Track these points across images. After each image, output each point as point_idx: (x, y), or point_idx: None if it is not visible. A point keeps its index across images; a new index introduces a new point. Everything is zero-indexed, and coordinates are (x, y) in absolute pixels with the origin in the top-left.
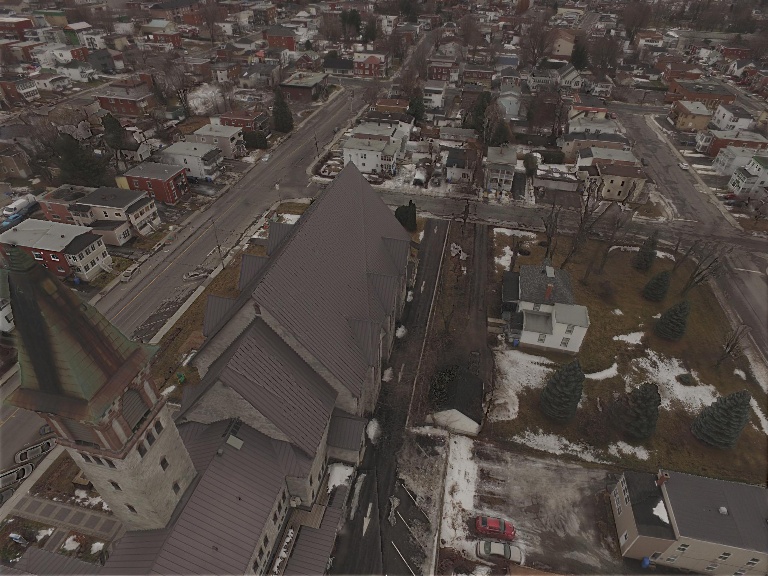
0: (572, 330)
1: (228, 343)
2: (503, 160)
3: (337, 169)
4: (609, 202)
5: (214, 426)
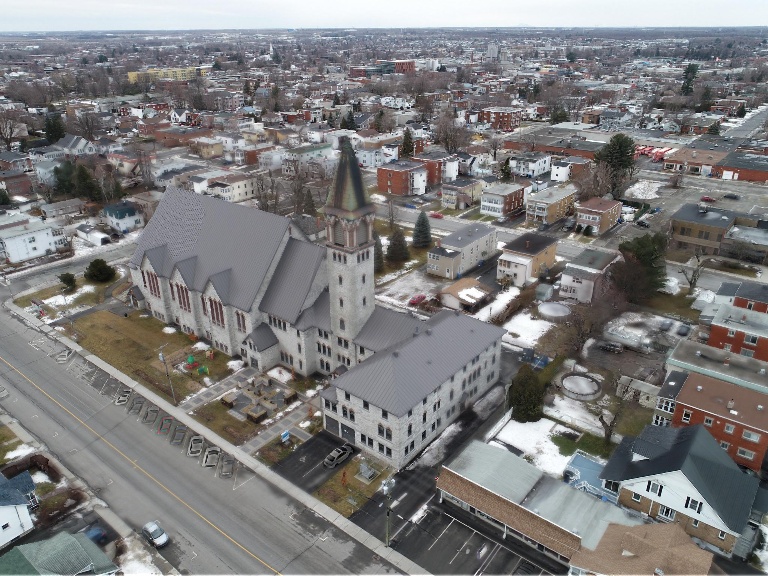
0: None
1: (272, 273)
2: None
3: (3, 266)
4: None
5: (317, 302)
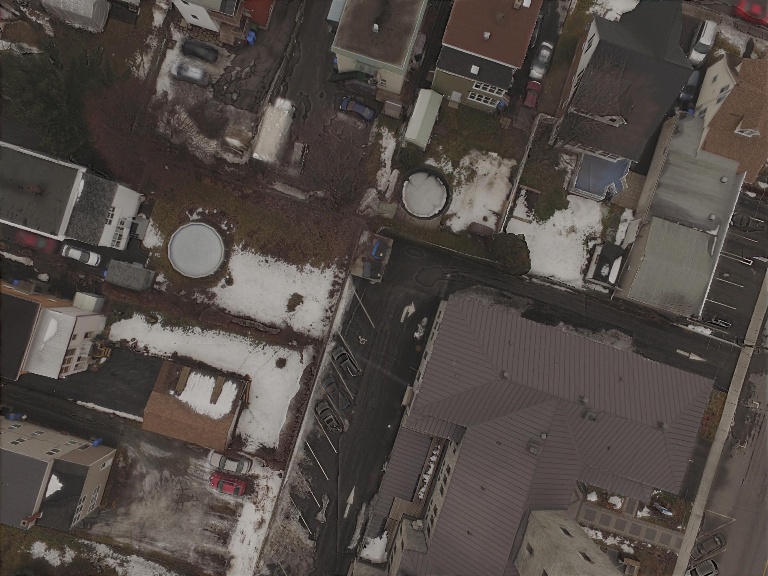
0: None
1: None
2: None
3: None
4: None
5: None
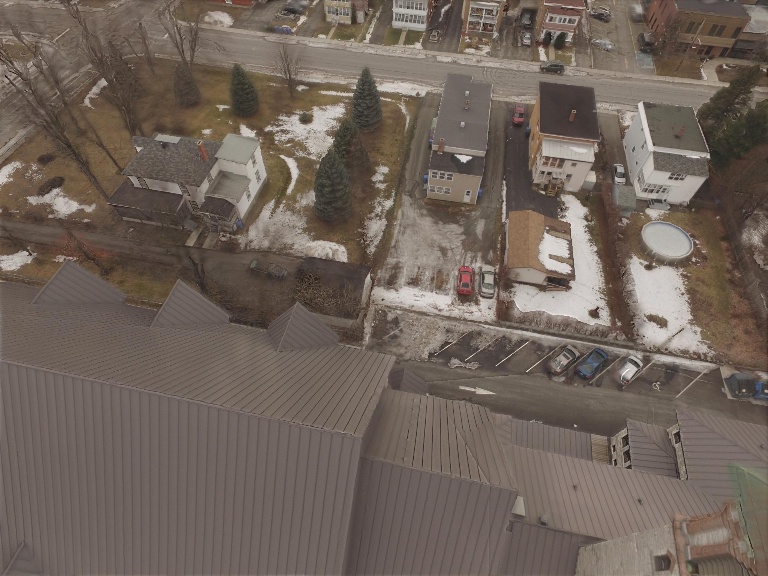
0: (254, 159)
1: None
2: None
3: None
4: None
5: None
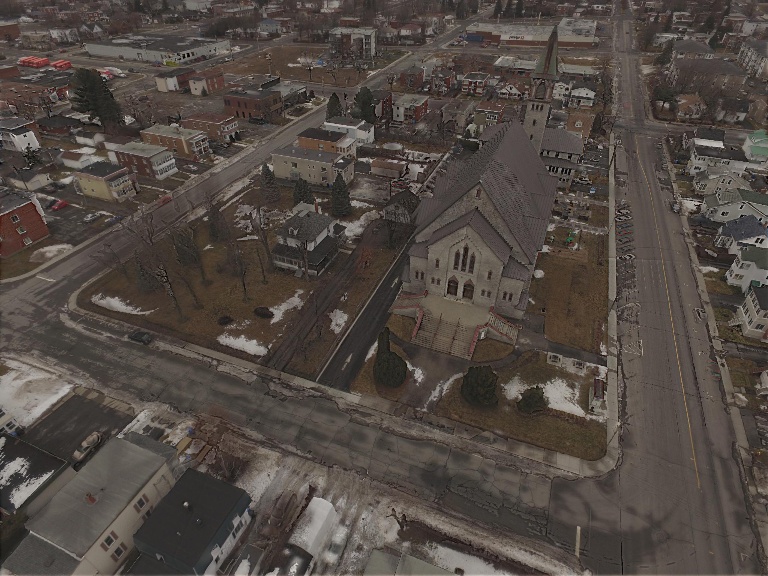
0: None
1: None
2: (125, 459)
3: None
4: (5, 405)
5: None
